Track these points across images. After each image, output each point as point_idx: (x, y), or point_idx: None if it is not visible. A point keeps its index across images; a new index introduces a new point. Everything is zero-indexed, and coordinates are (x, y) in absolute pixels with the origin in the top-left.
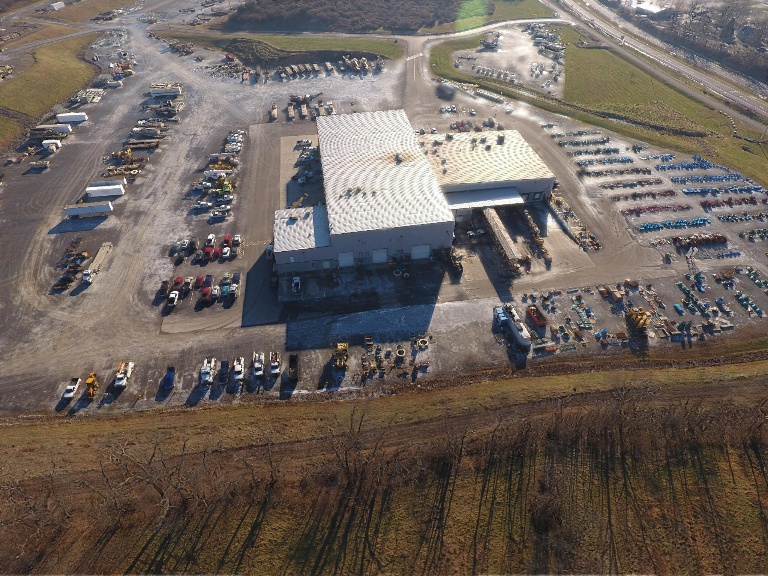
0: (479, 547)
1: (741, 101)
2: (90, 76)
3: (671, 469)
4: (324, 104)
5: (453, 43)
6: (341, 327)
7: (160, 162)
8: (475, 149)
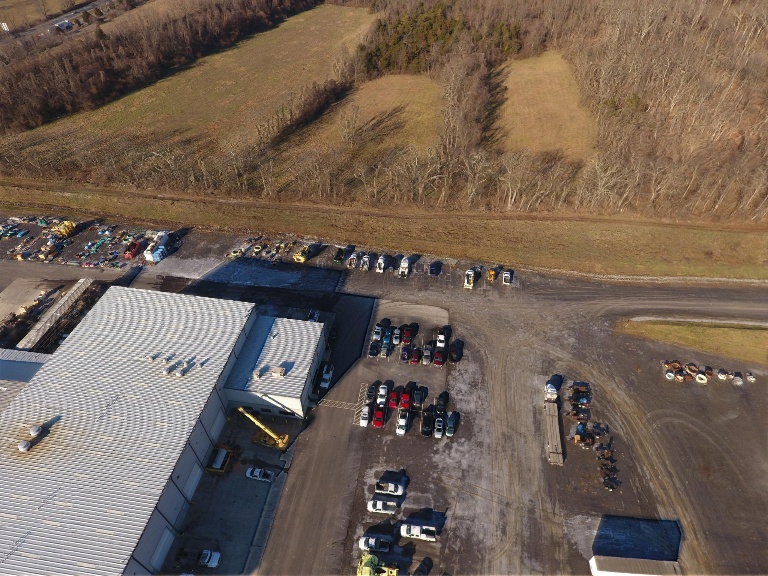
0: None
1: None
2: None
3: None
4: None
5: None
6: (290, 278)
7: None
8: None
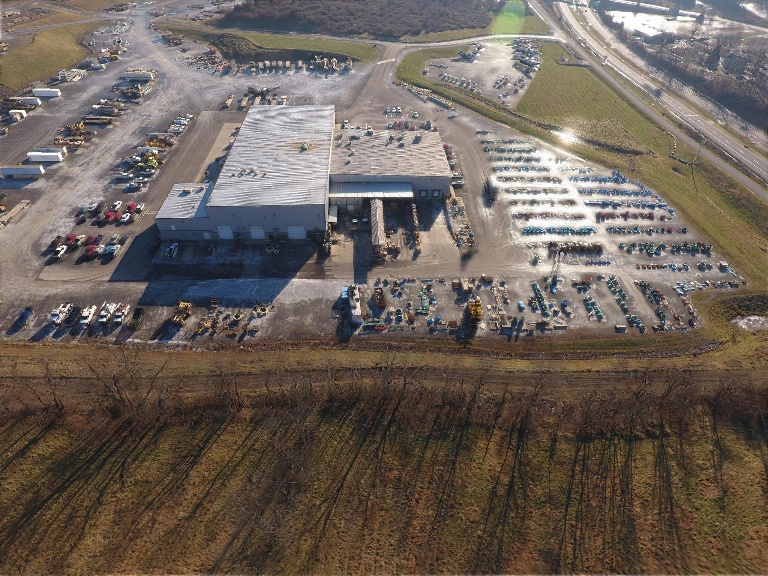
0: (217, 483)
1: (696, 125)
2: (80, 58)
3: (430, 441)
4: (279, 97)
5: (431, 51)
6: (196, 290)
7: (106, 137)
8: (388, 146)
